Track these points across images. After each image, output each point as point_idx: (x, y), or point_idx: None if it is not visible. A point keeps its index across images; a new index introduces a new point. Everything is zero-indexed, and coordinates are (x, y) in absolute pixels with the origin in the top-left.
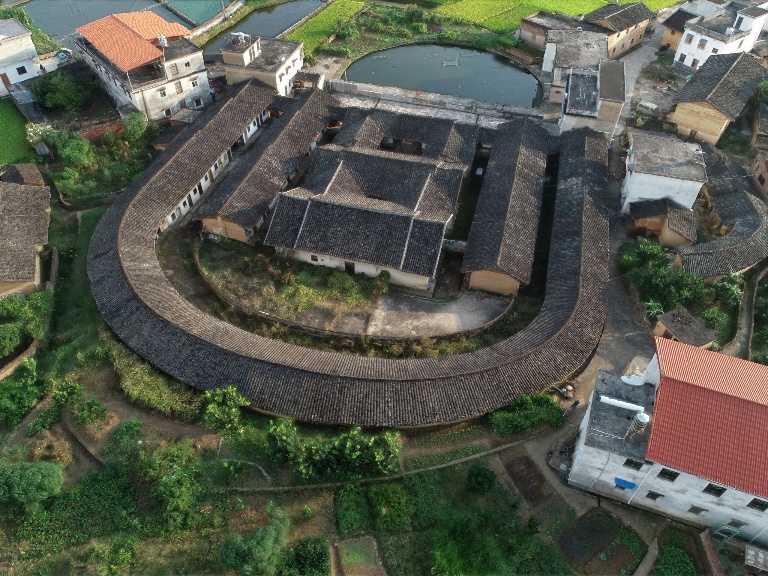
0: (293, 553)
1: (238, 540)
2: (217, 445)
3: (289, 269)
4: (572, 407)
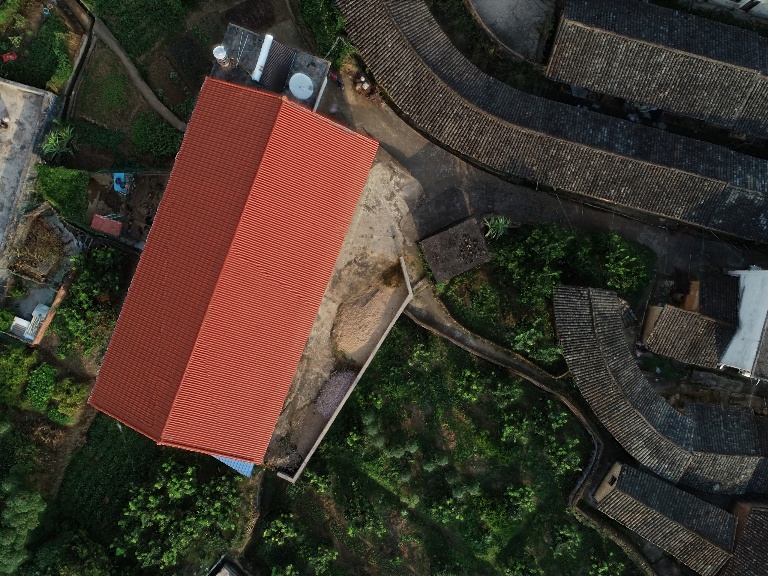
0: None
1: None
2: None
3: None
4: (336, 80)
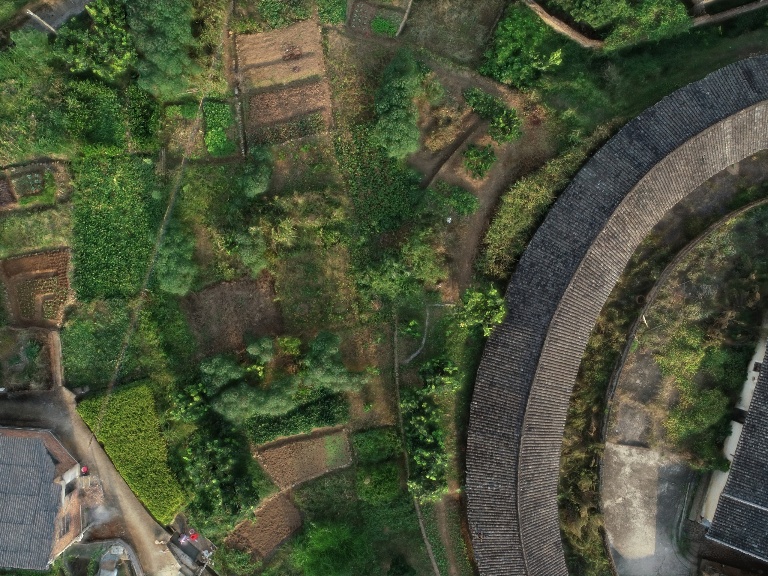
0: (334, 392)
1: (332, 351)
2: (446, 302)
3: (739, 332)
4: None
